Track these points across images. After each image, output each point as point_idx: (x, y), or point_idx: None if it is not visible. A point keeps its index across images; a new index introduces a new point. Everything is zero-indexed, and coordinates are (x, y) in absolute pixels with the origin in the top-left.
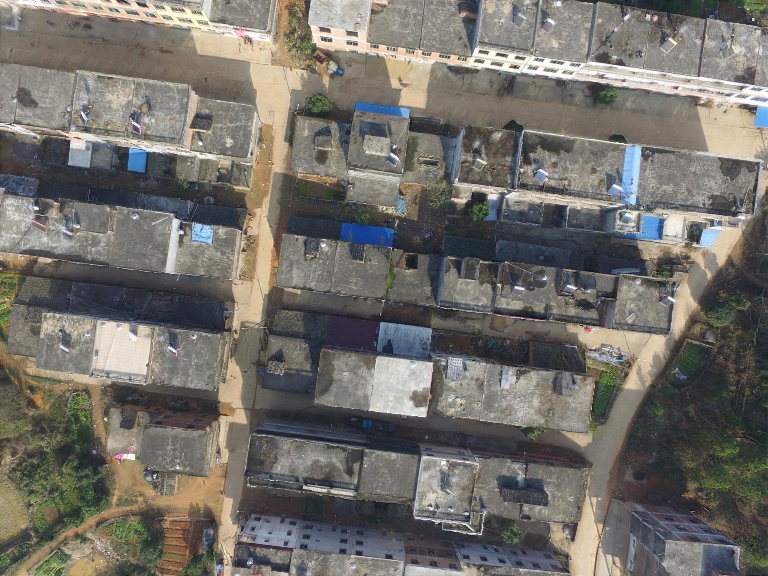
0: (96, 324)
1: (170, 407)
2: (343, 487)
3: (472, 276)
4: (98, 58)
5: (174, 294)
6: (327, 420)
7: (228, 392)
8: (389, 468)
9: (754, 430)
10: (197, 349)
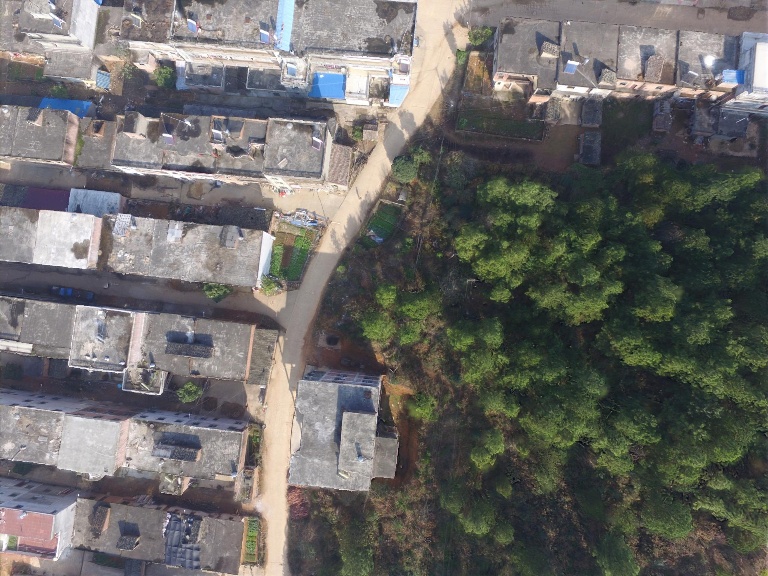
0: None
1: None
2: (8, 338)
3: (131, 129)
4: None
5: None
6: (33, 290)
7: None
8: (49, 318)
9: (429, 282)
10: None
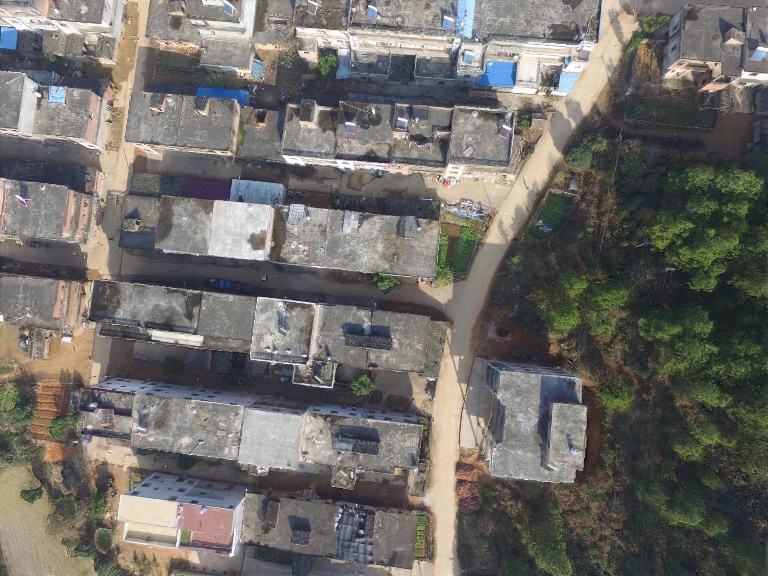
0: None
1: (41, 274)
2: (183, 331)
3: (307, 118)
4: None
5: None
6: (188, 283)
7: (96, 259)
8: (227, 310)
9: (613, 272)
10: (46, 200)
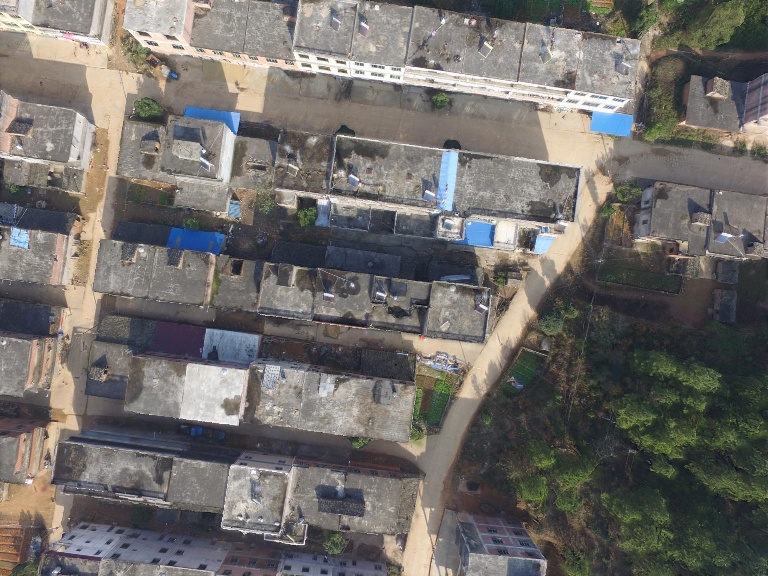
0: None
1: (0, 413)
2: (153, 496)
3: (285, 282)
4: None
5: (4, 299)
6: (158, 427)
7: (60, 398)
8: (198, 477)
9: (580, 441)
10: (7, 355)
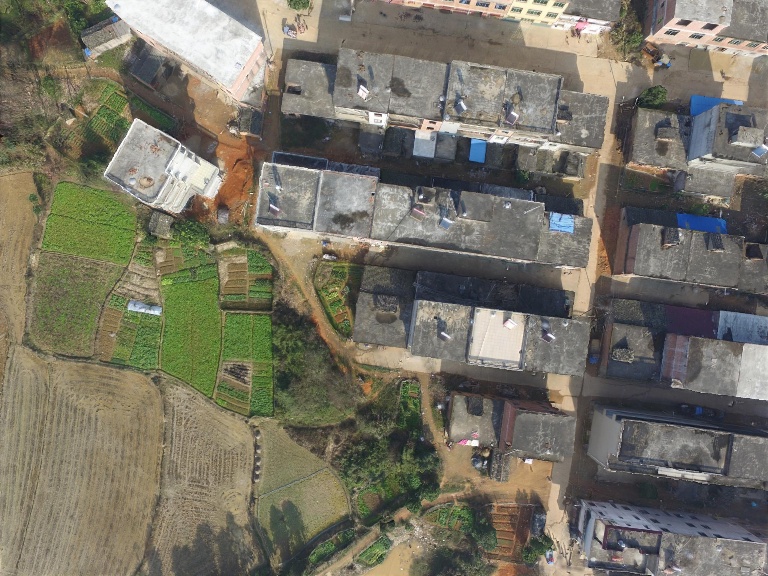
0: (474, 311)
1: (502, 394)
2: (710, 471)
3: None
4: (429, 49)
5: None
6: (655, 407)
7: (556, 380)
8: (757, 453)
9: None
10: (568, 336)
